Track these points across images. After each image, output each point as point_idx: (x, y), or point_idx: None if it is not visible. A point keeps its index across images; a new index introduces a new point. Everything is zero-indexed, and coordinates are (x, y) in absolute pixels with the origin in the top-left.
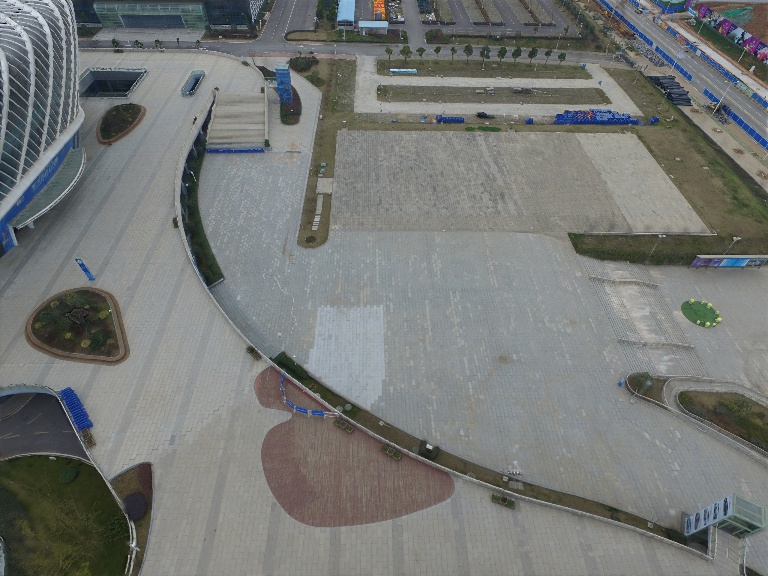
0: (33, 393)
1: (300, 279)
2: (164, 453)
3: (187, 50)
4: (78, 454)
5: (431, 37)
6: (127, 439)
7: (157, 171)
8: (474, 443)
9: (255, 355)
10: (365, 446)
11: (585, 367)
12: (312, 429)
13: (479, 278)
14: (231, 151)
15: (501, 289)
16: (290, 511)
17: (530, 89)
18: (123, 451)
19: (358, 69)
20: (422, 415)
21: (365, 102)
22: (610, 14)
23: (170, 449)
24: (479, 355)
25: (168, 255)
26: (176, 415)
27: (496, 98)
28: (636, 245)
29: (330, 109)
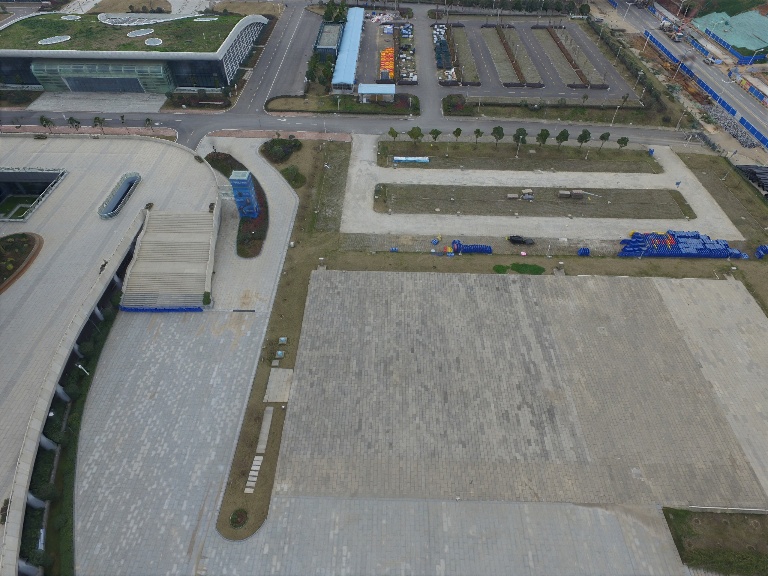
0: None
1: None
2: None
3: (128, 136)
4: None
5: (450, 106)
6: None
7: (18, 377)
8: None
9: None
10: None
11: None
12: None
13: None
14: (155, 309)
15: None
16: None
17: (582, 193)
18: None
19: (352, 156)
20: None
21: (356, 214)
22: (673, 65)
23: None
24: None
25: None
26: None
27: (535, 207)
28: None
29: (307, 227)
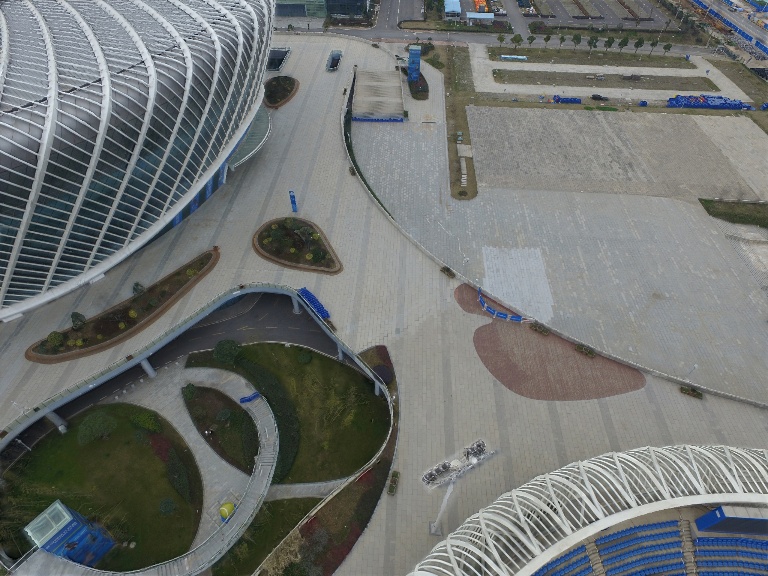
0: (257, 298)
1: (461, 224)
2: (394, 340)
3: (320, 33)
4: (306, 344)
5: (535, 28)
6: (361, 328)
7: (323, 131)
8: (643, 358)
9: (450, 274)
10: (561, 346)
11: (734, 306)
12: (512, 331)
13: (622, 231)
14: (374, 120)
15: (644, 241)
16: (510, 387)
17: (639, 76)
18: (360, 336)
19: (471, 55)
20: (593, 334)
21: (484, 83)
22: (703, 12)
23: (398, 337)
24: (634, 291)
25: (353, 196)
26: (395, 313)
27: (607, 83)
28: (765, 212)
29: (454, 88)
